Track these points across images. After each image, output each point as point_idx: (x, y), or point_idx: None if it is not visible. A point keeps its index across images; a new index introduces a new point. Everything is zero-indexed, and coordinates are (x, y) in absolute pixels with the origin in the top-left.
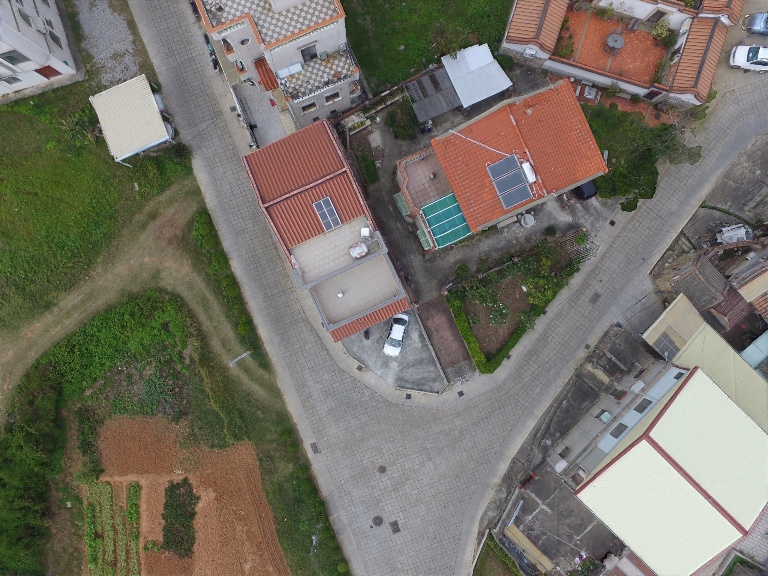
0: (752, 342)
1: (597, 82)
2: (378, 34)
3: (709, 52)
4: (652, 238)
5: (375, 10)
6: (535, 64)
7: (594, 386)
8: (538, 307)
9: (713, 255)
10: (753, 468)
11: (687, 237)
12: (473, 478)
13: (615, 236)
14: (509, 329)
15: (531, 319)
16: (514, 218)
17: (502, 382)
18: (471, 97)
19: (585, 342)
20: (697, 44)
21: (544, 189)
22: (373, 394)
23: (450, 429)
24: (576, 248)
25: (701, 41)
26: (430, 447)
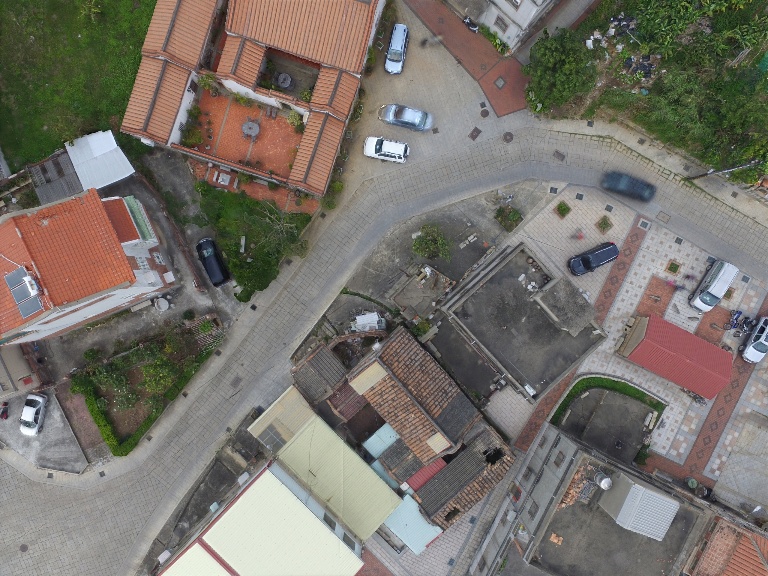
0: (375, 432)
1: (233, 168)
2: (20, 114)
3: (321, 147)
4: (293, 323)
5: (18, 90)
6: (172, 149)
7: (233, 470)
8: (169, 392)
9: (355, 341)
10: (316, 570)
11: (331, 322)
12: (115, 558)
13: (256, 320)
14: (150, 411)
15: (158, 404)
16: (149, 302)
17: (144, 463)
18: (93, 183)
19: (227, 425)
20: (310, 138)
21: (50, 302)
22: (15, 472)
23: (92, 509)
24: (202, 335)
25: (313, 135)
26: (72, 527)
